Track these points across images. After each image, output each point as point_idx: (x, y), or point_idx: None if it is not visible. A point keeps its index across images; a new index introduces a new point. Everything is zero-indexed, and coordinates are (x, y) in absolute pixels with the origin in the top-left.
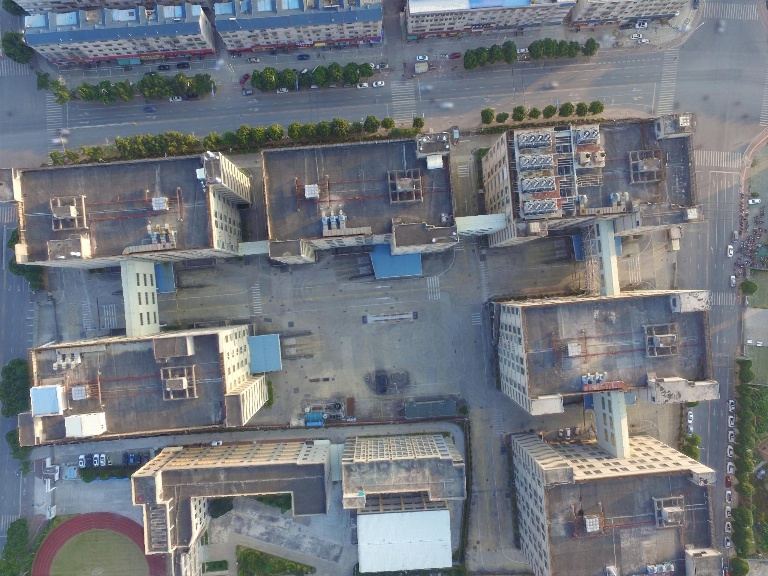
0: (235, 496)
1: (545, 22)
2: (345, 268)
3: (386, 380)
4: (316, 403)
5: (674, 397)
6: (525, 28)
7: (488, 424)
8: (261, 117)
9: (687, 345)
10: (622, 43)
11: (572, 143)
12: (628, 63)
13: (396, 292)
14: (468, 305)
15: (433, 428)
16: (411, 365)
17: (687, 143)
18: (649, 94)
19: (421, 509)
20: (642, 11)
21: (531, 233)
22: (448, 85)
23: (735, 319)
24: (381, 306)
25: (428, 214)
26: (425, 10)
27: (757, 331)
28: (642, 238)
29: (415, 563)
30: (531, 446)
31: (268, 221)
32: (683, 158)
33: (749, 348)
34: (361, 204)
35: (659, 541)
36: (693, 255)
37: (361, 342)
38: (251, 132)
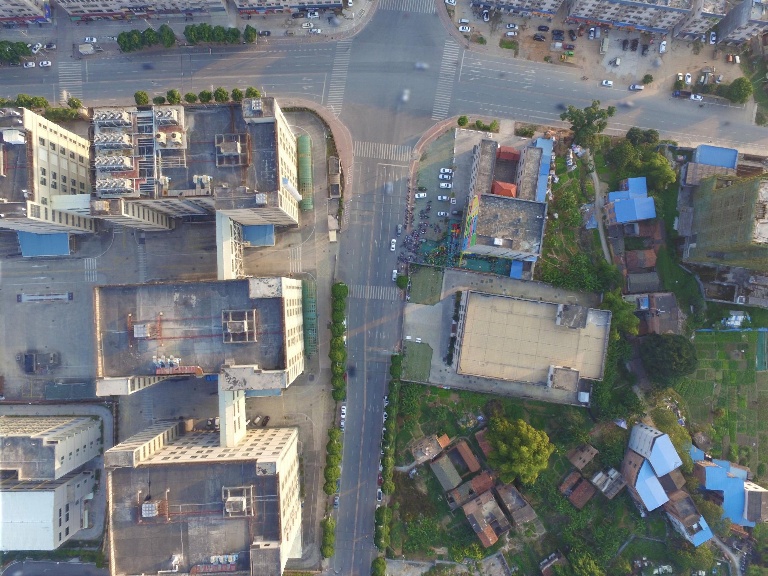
0: None
1: (206, 7)
2: (3, 246)
3: (34, 360)
4: None
5: (239, 384)
6: (193, 13)
7: (138, 409)
8: None
9: (267, 332)
10: (291, 32)
11: (153, 123)
12: (299, 52)
13: (52, 272)
14: None
15: (83, 411)
16: (63, 346)
17: None
18: (319, 84)
19: (27, 489)
20: None
21: (101, 212)
22: (116, 67)
23: (396, 314)
24: (36, 285)
25: (12, 189)
26: None
27: (418, 327)
28: (305, 228)
29: (16, 544)
30: (148, 431)
31: None
32: (273, 143)
33: (409, 344)
34: None
35: (228, 531)
36: (356, 247)
37: (14, 321)
38: None
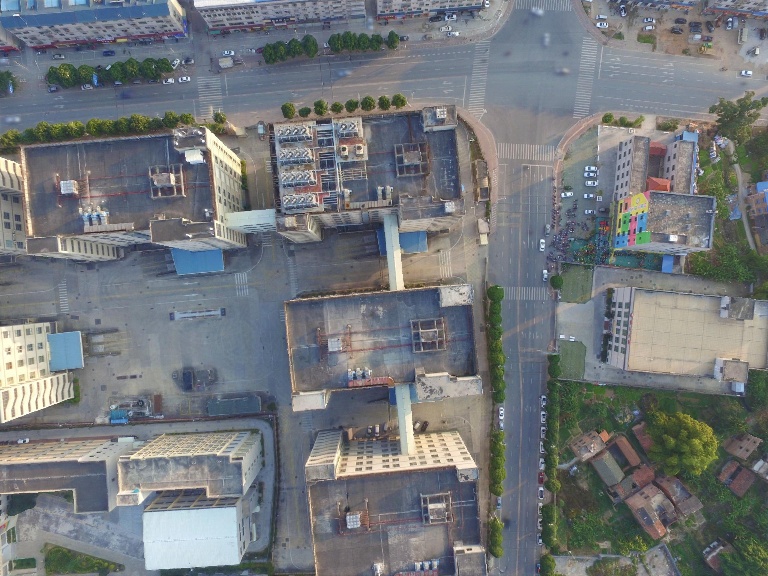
0: (38, 494)
1: (347, 15)
2: (152, 265)
3: (192, 377)
4: (123, 400)
5: (436, 392)
6: (331, 22)
7: (297, 421)
8: (67, 114)
9: (456, 340)
10: (430, 36)
11: (334, 136)
12: (438, 56)
13: (204, 289)
14: (276, 301)
15: (242, 425)
16: (219, 362)
17: (455, 136)
18: (460, 87)
19: (208, 506)
20: (443, 3)
21: (289, 228)
22: (255, 80)
23: (548, 314)
24: (188, 303)
25: (192, 209)
26: (210, 4)
27: (570, 326)
28: (453, 233)
29: (201, 560)
30: (322, 443)
31: (28, 218)
32: (451, 151)
33: (562, 343)
34: (124, 200)
35: (427, 538)
36: (505, 249)
37: (169, 339)
38: (49, 129)
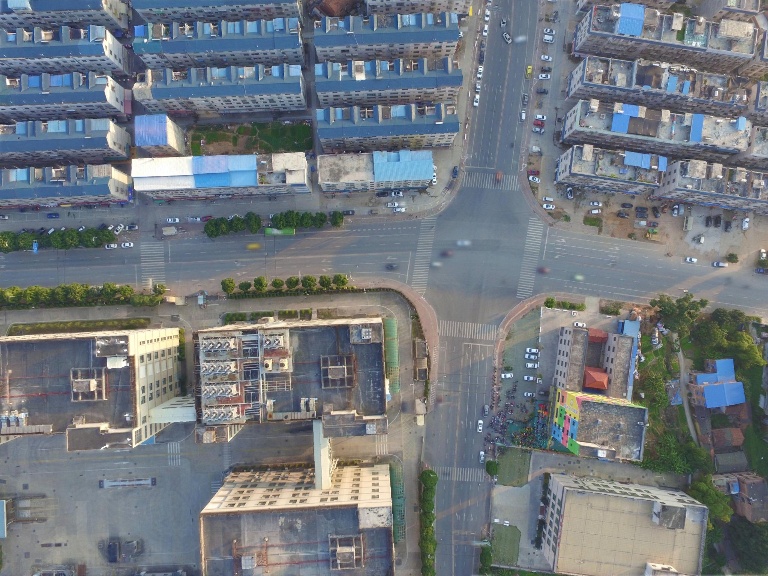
0: None
1: (292, 192)
2: None
3: (117, 549)
4: (46, 569)
5: None
6: (277, 194)
7: None
8: (7, 274)
9: (374, 557)
10: (376, 212)
11: (259, 347)
12: (383, 231)
13: (135, 457)
14: (208, 473)
15: None
16: (147, 533)
17: None
18: (404, 263)
19: None
20: (388, 186)
21: None
22: (199, 248)
23: (483, 496)
24: (119, 471)
25: (113, 412)
26: (150, 188)
27: (505, 509)
28: (390, 409)
29: None
30: None
31: None
32: (378, 363)
33: (497, 527)
34: (44, 400)
35: None
36: (443, 428)
37: (96, 507)
38: None
